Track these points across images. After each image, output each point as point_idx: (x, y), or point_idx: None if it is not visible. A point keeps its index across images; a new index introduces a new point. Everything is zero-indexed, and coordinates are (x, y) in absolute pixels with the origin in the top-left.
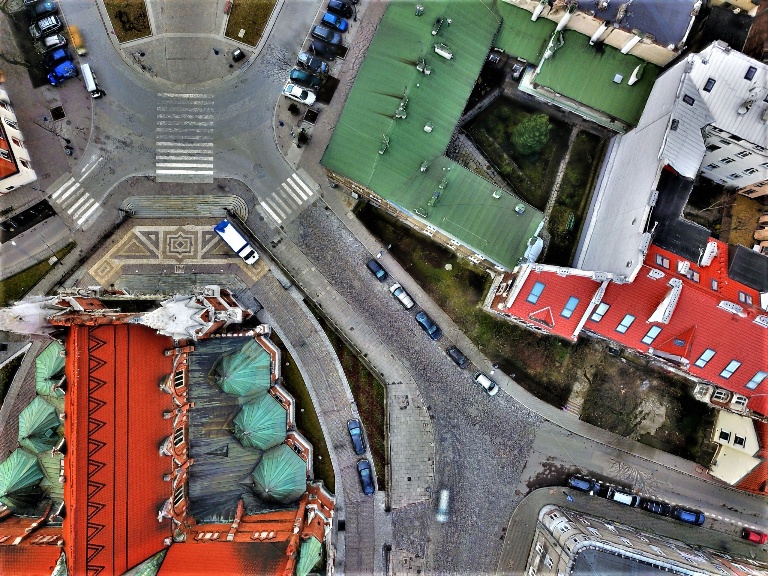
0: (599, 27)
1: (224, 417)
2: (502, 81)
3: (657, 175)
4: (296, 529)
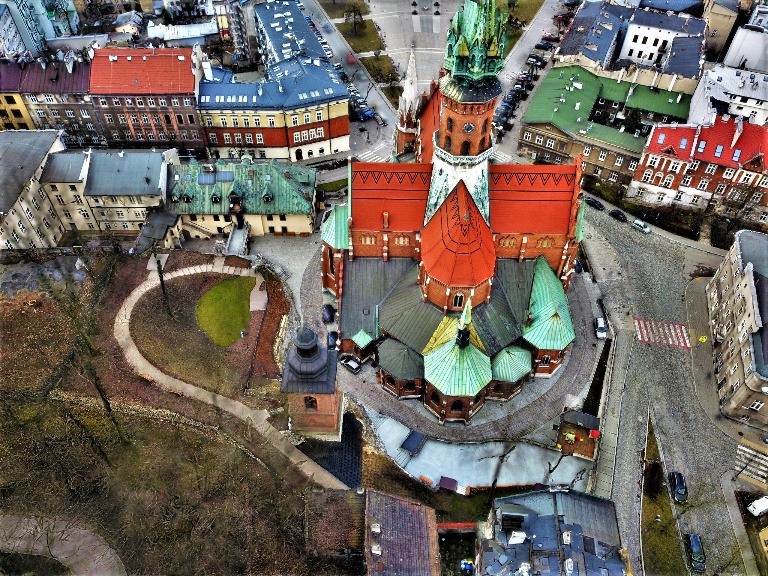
0: (654, 76)
1: None
2: (604, 124)
3: (708, 99)
4: None
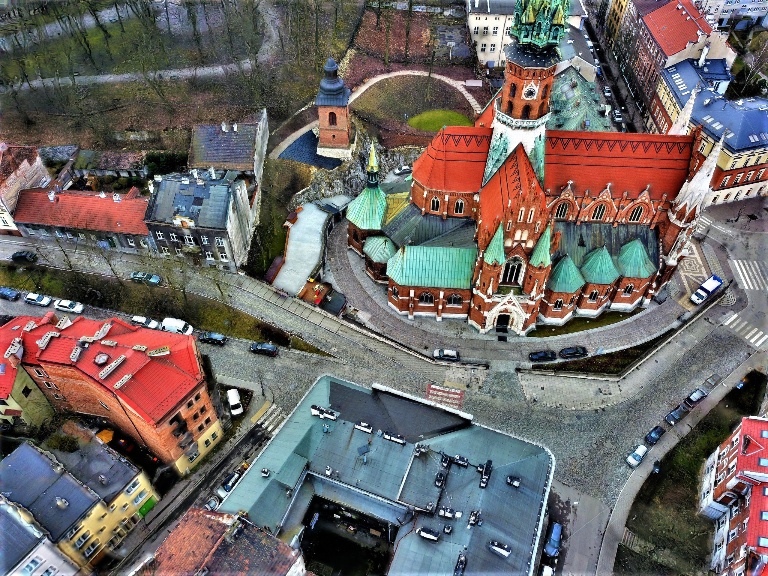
0: None
1: None
2: None
3: None
4: None
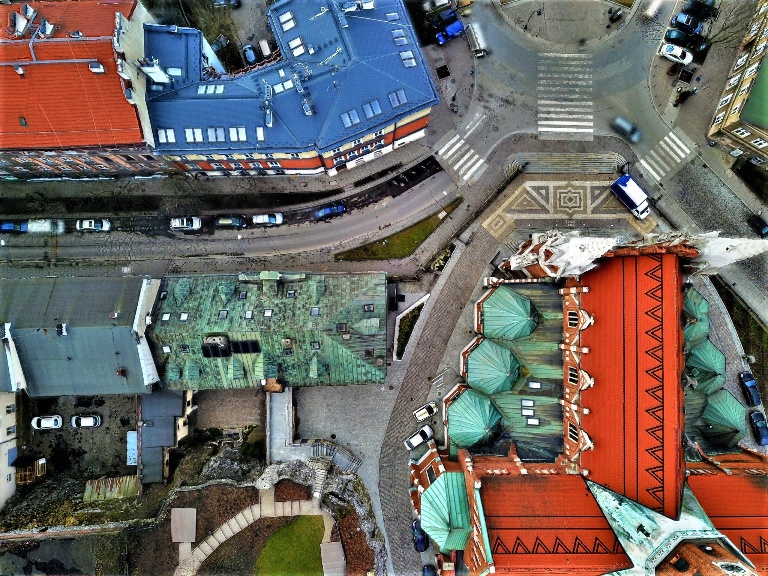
0: None
1: None
2: None
3: None
4: None
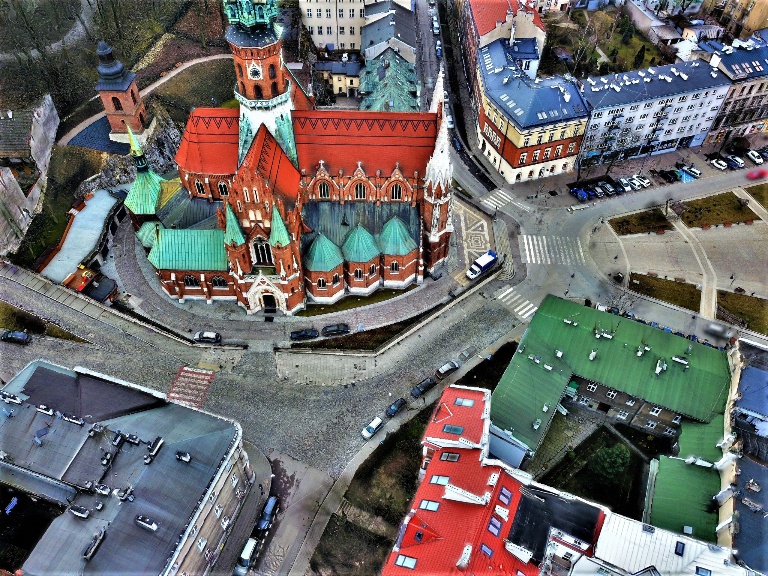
0: None
1: (367, 225)
2: None
3: None
4: (294, 238)
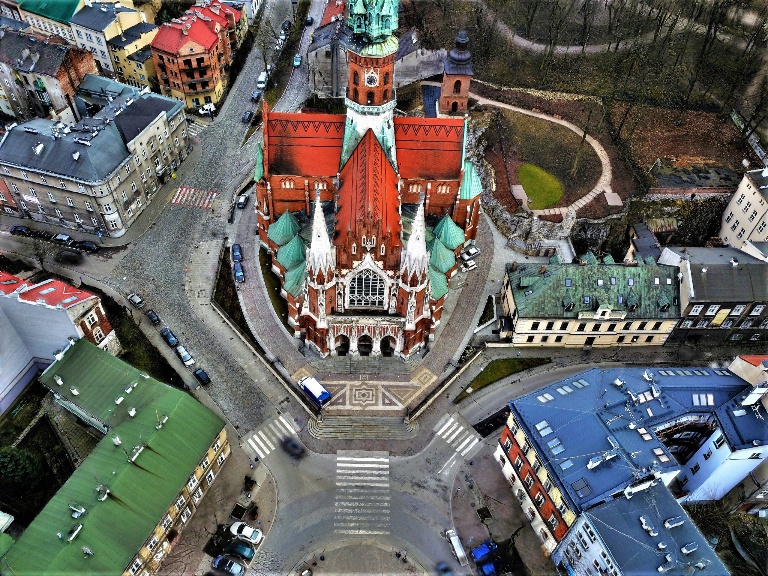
0: None
1: None
2: None
3: None
4: (269, 188)
